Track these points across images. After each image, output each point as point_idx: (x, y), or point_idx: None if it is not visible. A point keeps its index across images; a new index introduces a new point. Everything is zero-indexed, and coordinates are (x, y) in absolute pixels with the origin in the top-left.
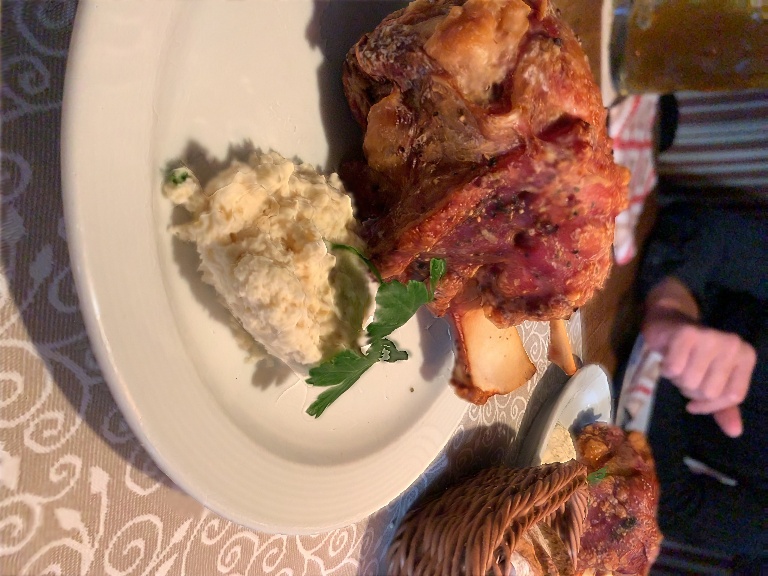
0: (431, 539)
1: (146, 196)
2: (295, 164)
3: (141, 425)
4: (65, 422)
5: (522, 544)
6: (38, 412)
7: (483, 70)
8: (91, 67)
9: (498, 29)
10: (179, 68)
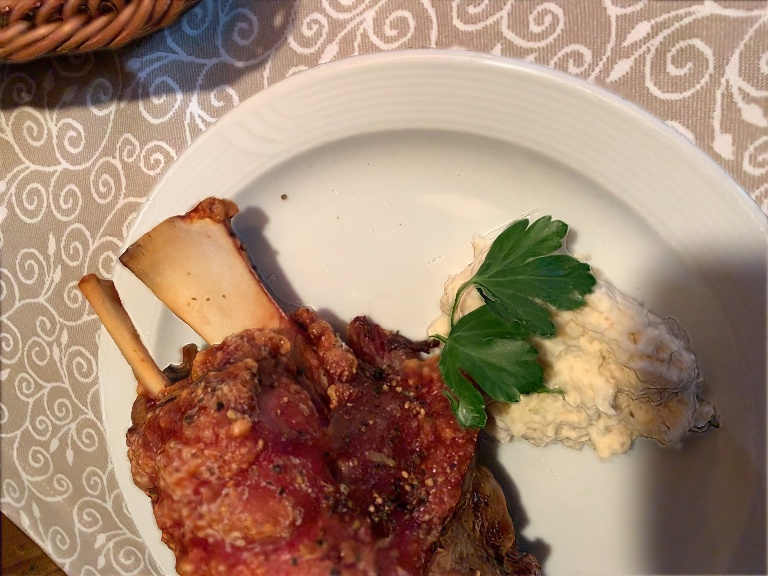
0: None
1: (754, 413)
2: None
3: (762, 228)
4: (760, 205)
5: None
6: None
7: None
8: None
9: None
10: None
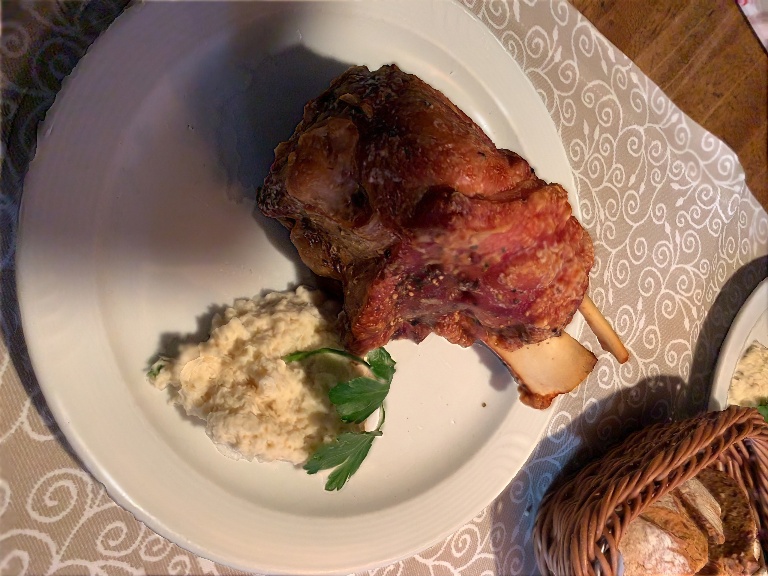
0: (557, 526)
1: (130, 401)
2: (264, 296)
3: (189, 542)
4: None
5: (664, 514)
6: (143, 538)
7: (334, 194)
8: (48, 358)
9: (330, 155)
10: None
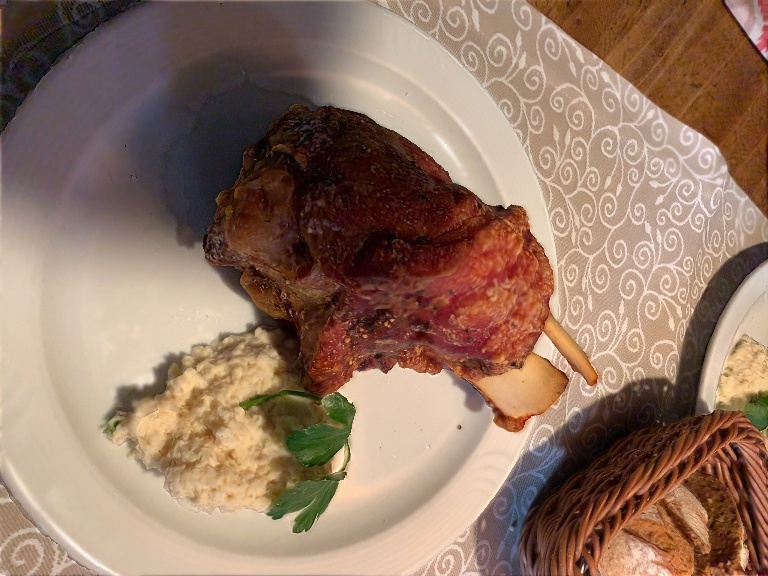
0: (541, 542)
1: (87, 461)
2: (222, 339)
3: None
4: None
5: (648, 526)
6: None
7: (274, 245)
8: None
9: (266, 208)
10: None
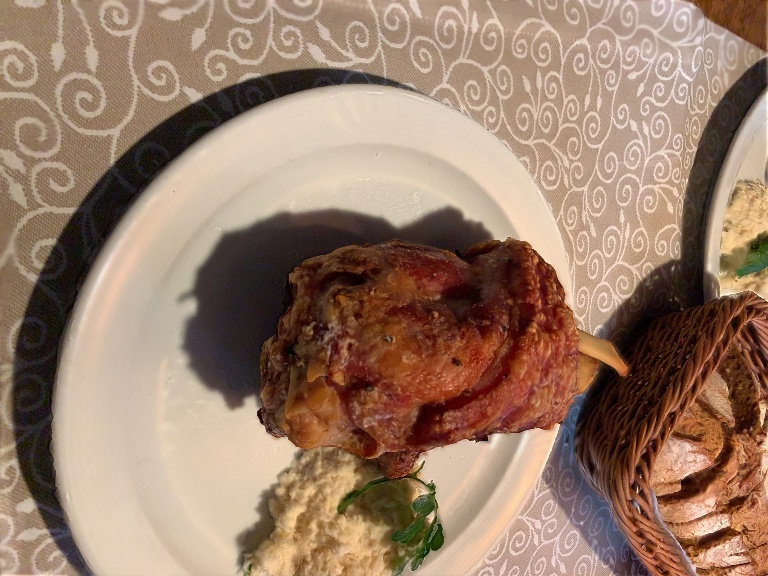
0: None
1: None
2: (298, 457)
3: None
4: None
5: (681, 422)
6: None
7: (336, 440)
8: None
9: (320, 421)
10: (197, 548)
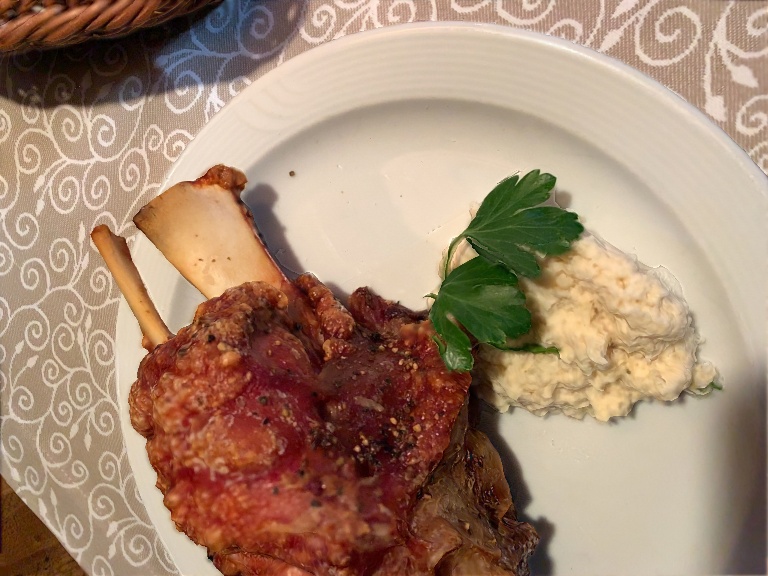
0: None
1: (757, 371)
2: None
3: (751, 176)
4: None
5: None
6: None
7: None
8: None
9: None
10: None
